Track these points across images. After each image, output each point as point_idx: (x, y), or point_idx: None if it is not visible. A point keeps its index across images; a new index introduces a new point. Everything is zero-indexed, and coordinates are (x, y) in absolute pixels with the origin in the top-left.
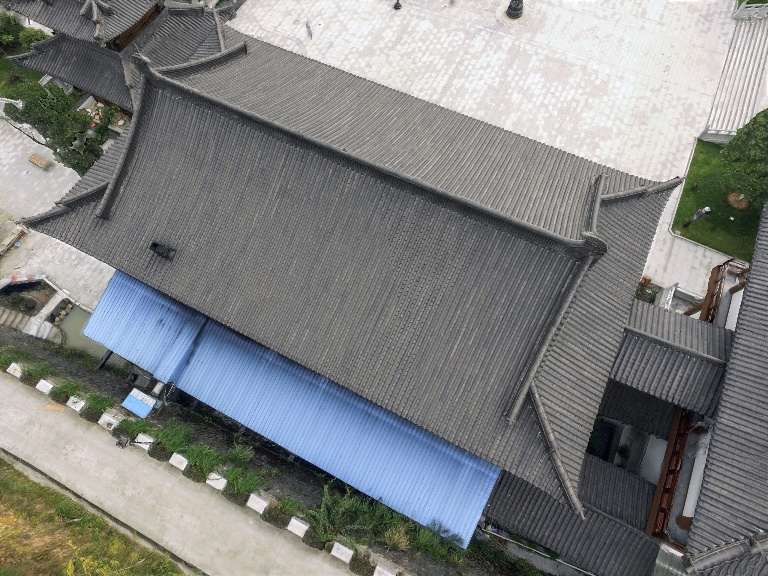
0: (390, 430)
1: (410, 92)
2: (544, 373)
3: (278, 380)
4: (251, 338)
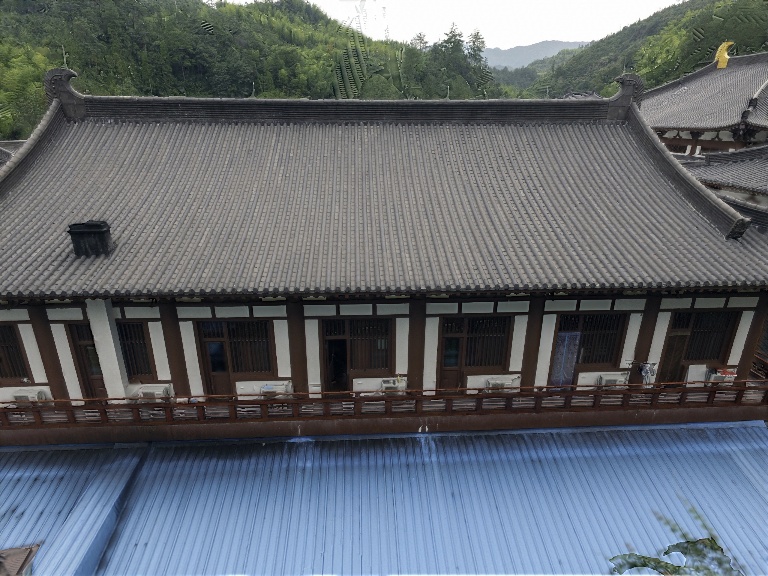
0: (590, 467)
1: None
2: None
3: (343, 490)
4: (317, 288)
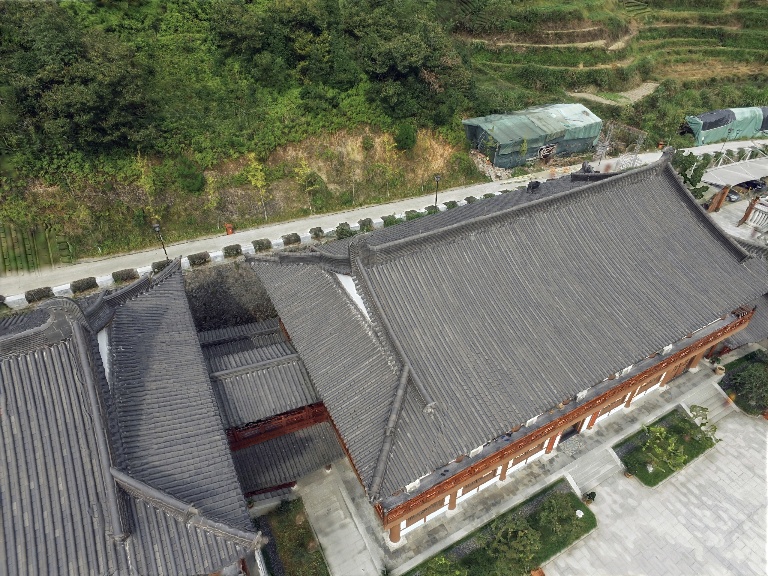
0: None
1: None
2: (318, 275)
3: None
4: None
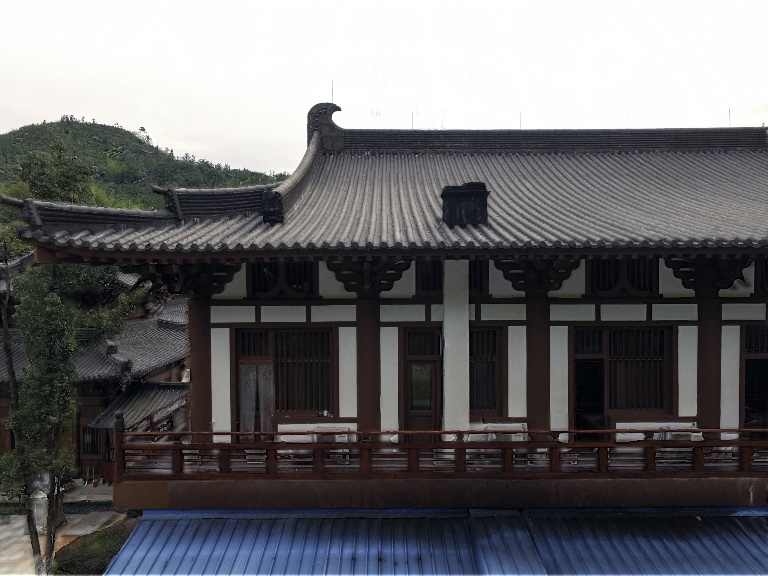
0: None
1: None
2: None
3: None
4: None
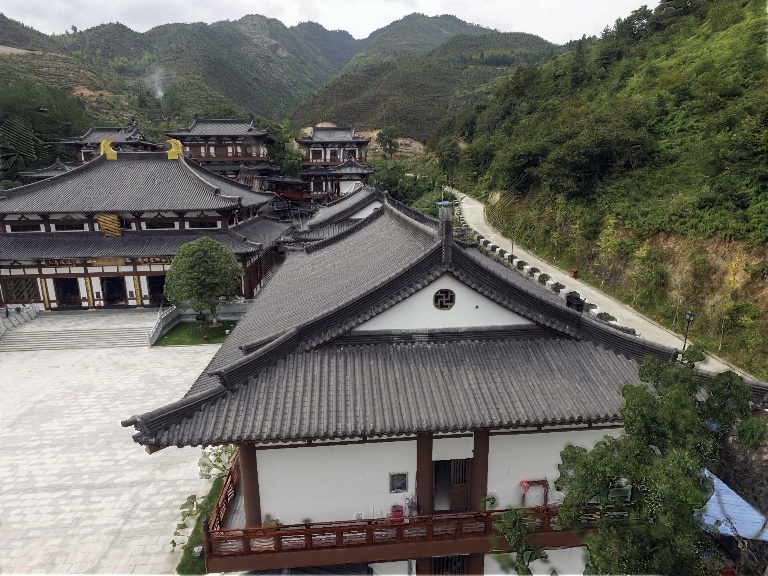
0: None
1: (60, 523)
2: None
3: None
4: None
